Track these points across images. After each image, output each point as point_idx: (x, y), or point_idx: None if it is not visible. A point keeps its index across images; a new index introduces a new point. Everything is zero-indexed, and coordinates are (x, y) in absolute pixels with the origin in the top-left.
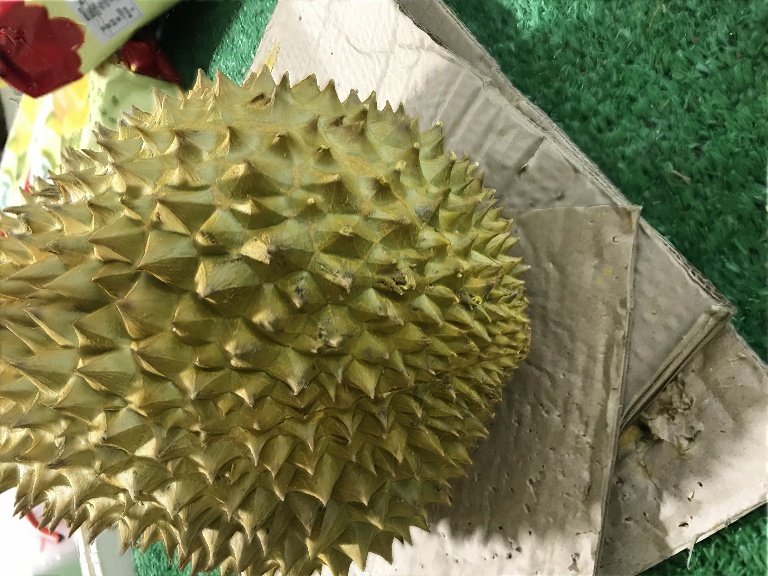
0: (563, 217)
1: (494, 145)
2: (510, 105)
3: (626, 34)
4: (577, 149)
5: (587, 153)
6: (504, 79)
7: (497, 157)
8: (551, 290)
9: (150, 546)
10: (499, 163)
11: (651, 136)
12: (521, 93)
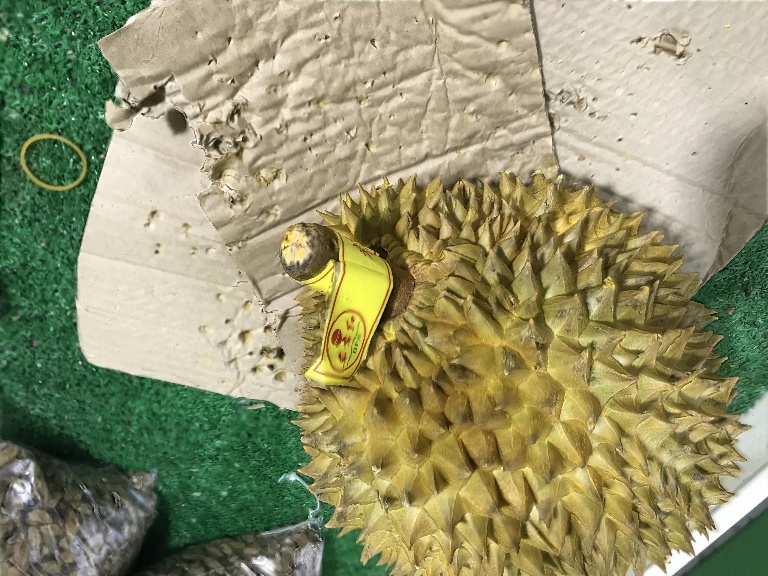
0: None
1: None
2: None
3: None
4: None
5: None
6: None
7: None
8: None
9: None
10: None
11: None
12: None
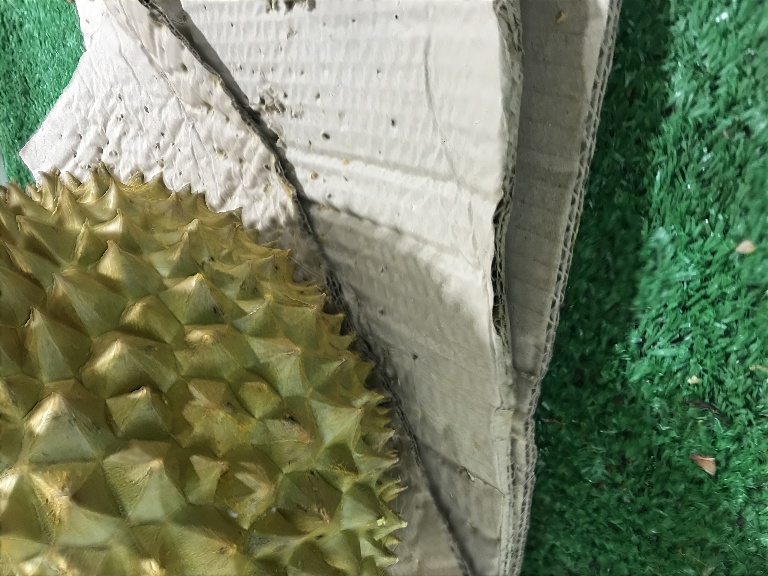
0: (451, 567)
1: (462, 438)
2: (507, 440)
3: (665, 524)
4: (527, 507)
5: (533, 512)
6: (529, 408)
7: (456, 445)
8: (404, 567)
9: (14, 130)
10: (454, 449)
11: (583, 574)
12: (533, 427)
